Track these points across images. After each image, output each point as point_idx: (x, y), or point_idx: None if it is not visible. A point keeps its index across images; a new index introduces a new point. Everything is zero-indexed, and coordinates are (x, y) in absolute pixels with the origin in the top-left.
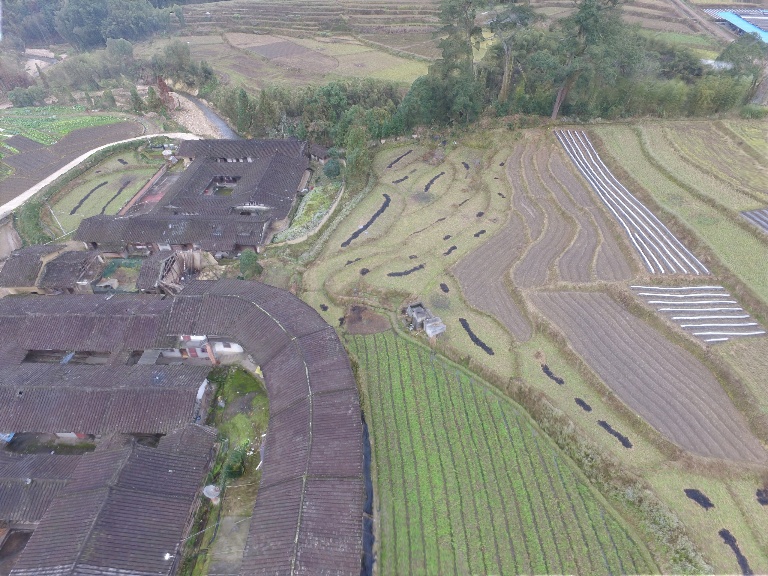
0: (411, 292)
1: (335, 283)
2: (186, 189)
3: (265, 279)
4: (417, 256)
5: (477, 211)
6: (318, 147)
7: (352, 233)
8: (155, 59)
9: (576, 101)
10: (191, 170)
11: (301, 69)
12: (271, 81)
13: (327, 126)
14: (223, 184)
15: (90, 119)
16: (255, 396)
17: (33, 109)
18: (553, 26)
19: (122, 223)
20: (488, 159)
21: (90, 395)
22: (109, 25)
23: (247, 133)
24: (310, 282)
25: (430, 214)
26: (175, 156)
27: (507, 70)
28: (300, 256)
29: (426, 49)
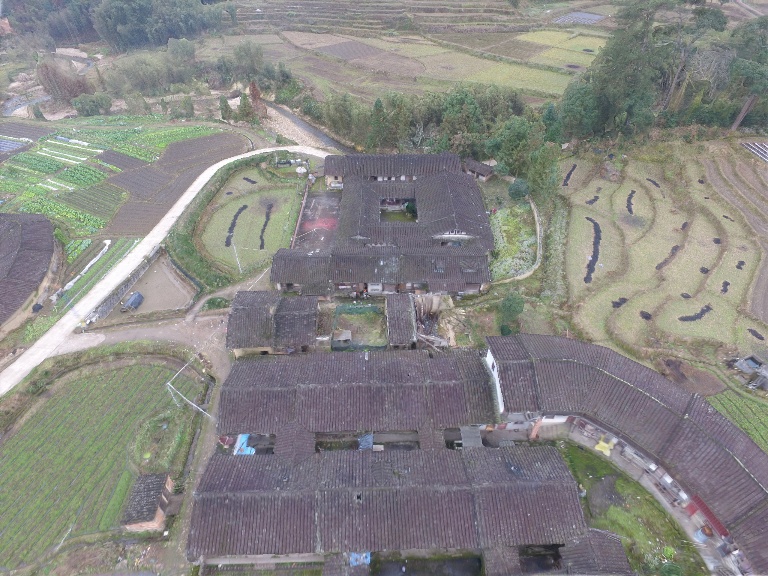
0: (722, 341)
1: (624, 331)
2: (364, 215)
3: (525, 326)
4: (689, 294)
5: (711, 237)
6: (475, 162)
7: (586, 266)
8: (223, 61)
9: (760, 111)
10: (353, 192)
11: (388, 72)
12: (362, 86)
13: (474, 138)
14: (384, 206)
15: (183, 130)
16: (615, 481)
17: (105, 118)
18: (737, 31)
19: (322, 260)
20: (677, 175)
21: (447, 496)
22: (155, 23)
23: (357, 144)
24: (590, 330)
25: (658, 241)
26: (313, 174)
27: (687, 78)
28: (544, 295)
29: (509, 50)
